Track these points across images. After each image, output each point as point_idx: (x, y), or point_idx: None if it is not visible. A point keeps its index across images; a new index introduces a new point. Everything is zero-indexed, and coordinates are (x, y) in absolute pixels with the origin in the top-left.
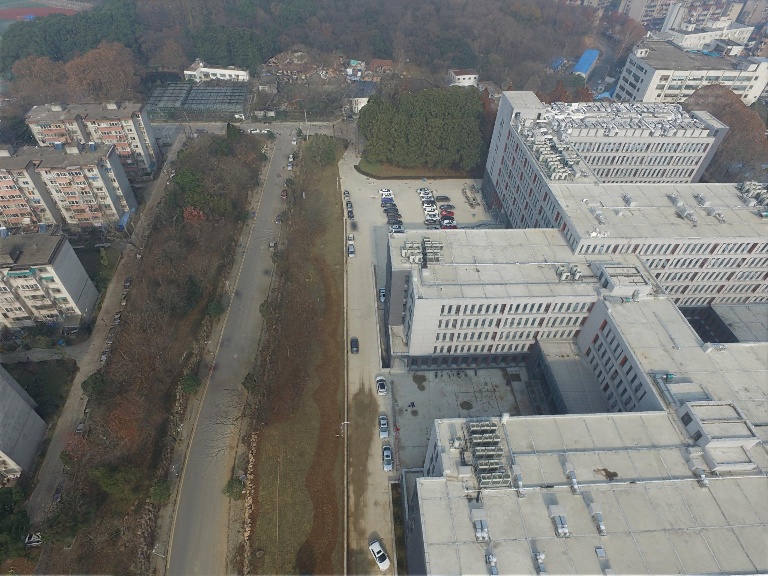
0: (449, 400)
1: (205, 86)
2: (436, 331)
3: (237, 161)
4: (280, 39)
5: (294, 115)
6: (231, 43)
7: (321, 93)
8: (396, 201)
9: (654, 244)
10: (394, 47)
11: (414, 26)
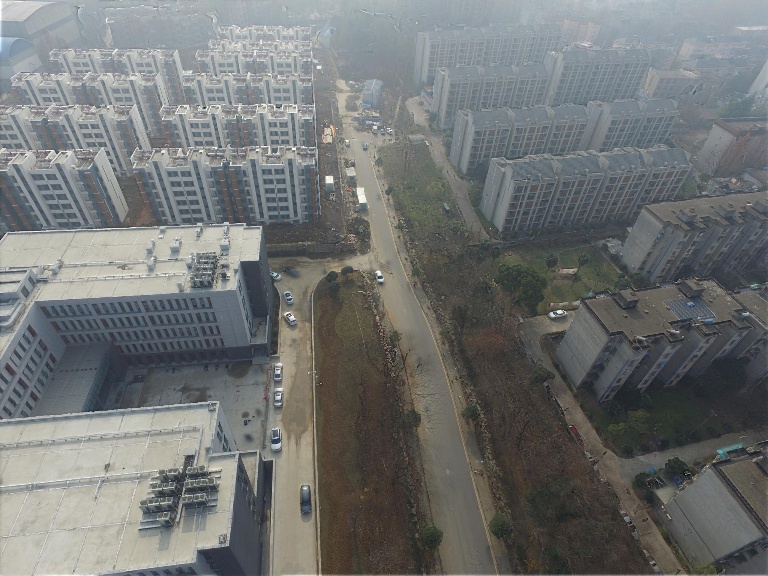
0: None
1: None
2: None
3: None
4: None
5: None
6: None
7: None
8: None
9: None
10: None
11: None
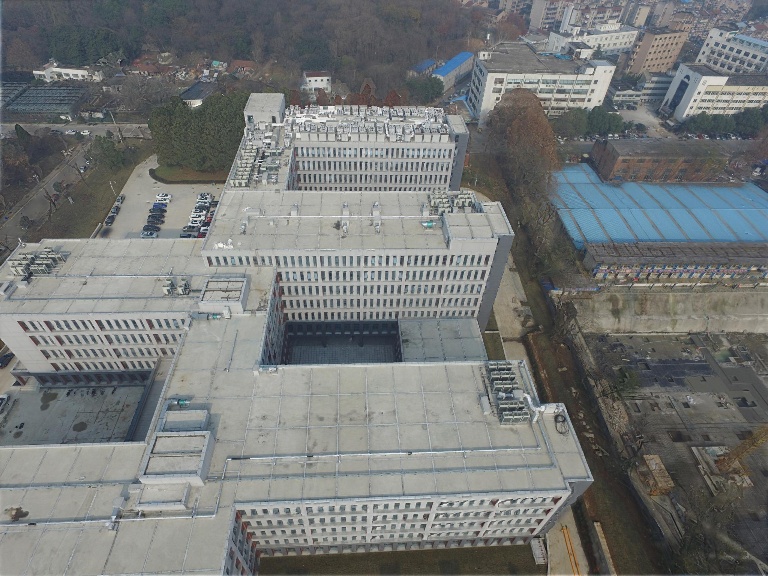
0: (65, 421)
1: (44, 86)
2: (37, 348)
3: (1, 164)
4: (143, 39)
5: (120, 117)
6: (84, 43)
7: (137, 94)
8: (169, 206)
9: (289, 256)
10: (256, 48)
11: (286, 27)
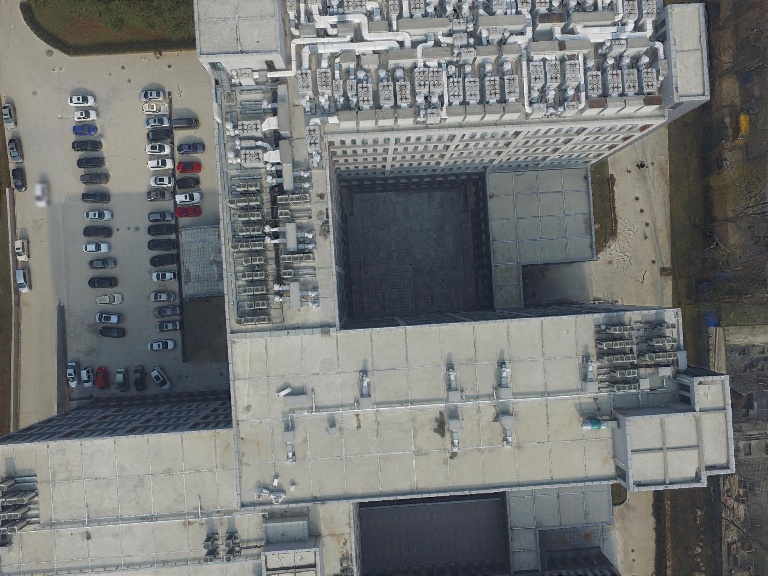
0: None
1: None
2: None
3: None
4: None
5: None
6: None
7: None
8: (102, 129)
9: None
10: None
11: None
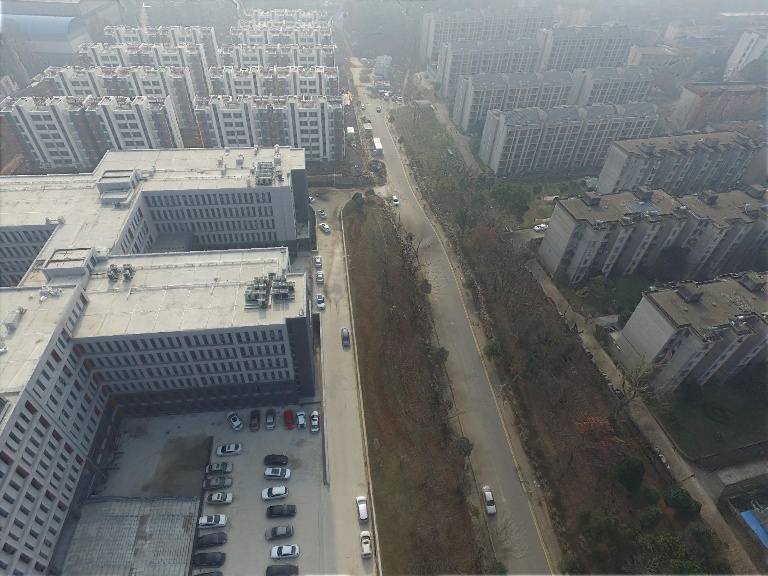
0: None
1: None
2: None
3: None
4: None
5: None
6: None
7: None
8: None
9: None
10: None
11: None
